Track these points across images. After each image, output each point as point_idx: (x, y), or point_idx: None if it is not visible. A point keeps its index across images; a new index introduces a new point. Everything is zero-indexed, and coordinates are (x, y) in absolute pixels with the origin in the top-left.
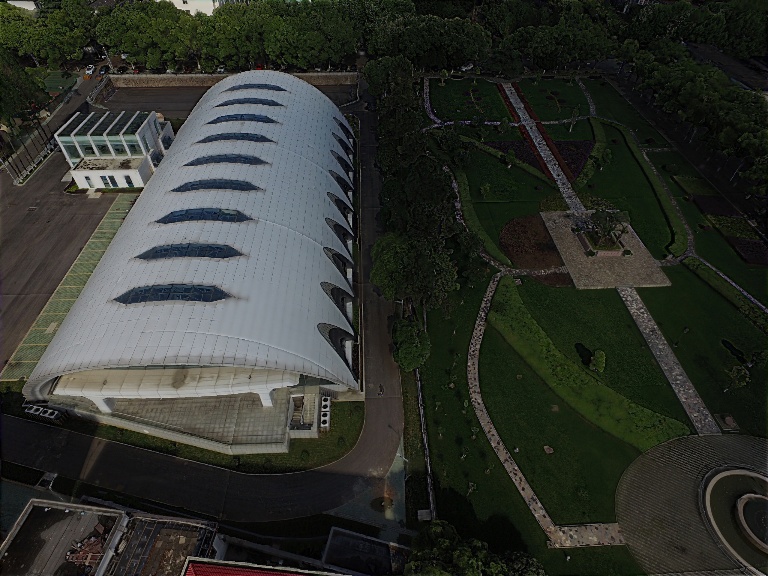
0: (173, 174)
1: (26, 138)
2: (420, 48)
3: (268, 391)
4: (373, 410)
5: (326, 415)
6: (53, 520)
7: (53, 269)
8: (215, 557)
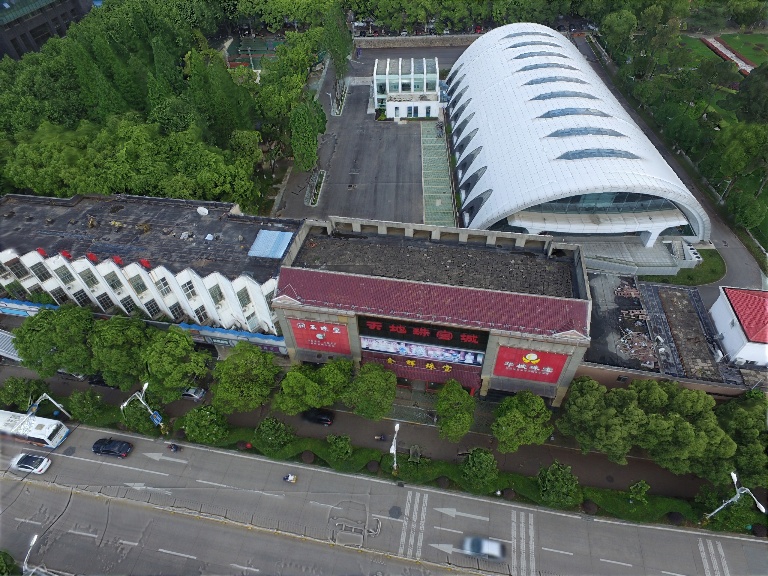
0: (517, 91)
1: (316, 85)
2: (633, 7)
3: (661, 230)
4: (727, 254)
5: (697, 253)
6: (589, 278)
7: (410, 168)
8: None
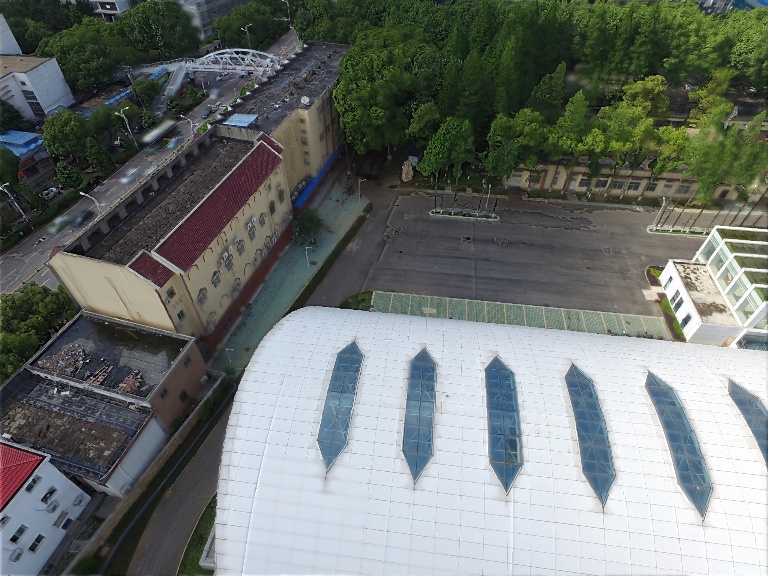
0: (625, 361)
1: (743, 209)
2: None
3: None
4: None
5: None
6: (171, 355)
7: (512, 291)
8: (106, 487)
